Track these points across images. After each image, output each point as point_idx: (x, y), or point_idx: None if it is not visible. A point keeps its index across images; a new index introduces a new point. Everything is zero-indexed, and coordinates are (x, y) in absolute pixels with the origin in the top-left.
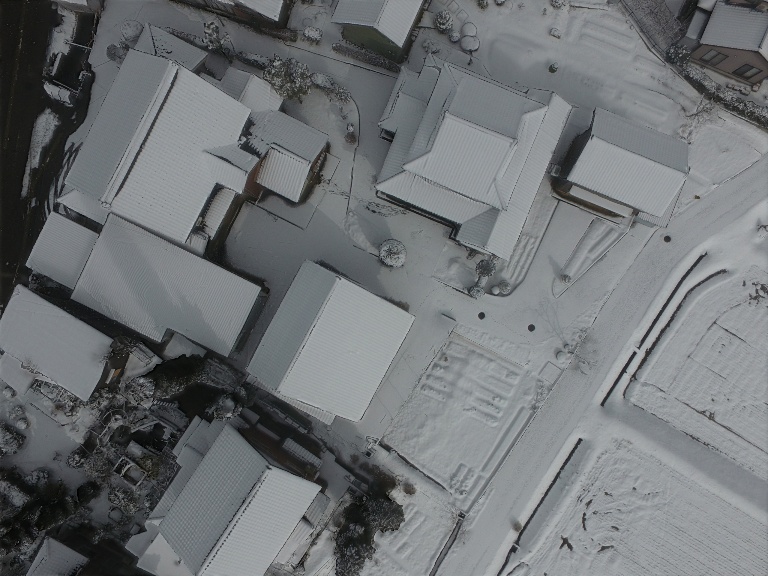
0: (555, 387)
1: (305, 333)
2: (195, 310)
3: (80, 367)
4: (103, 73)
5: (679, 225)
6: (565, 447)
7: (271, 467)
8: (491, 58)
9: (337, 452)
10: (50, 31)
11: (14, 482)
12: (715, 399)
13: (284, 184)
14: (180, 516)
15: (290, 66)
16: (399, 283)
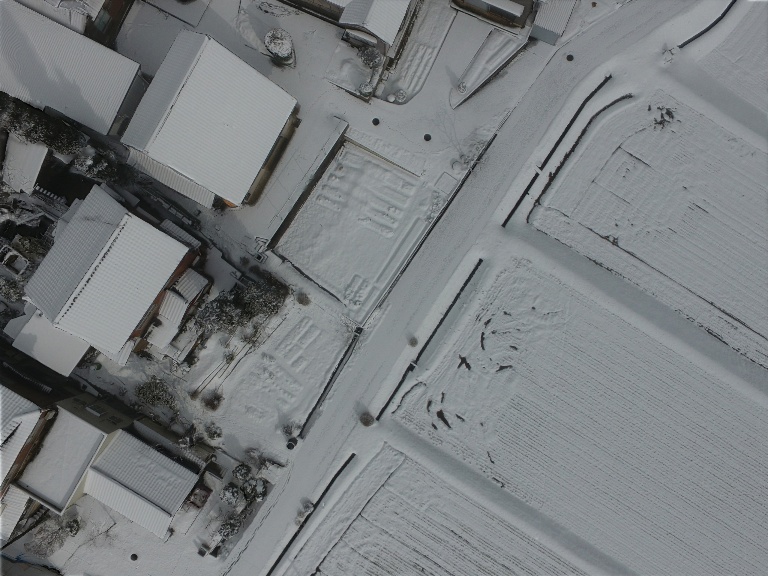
0: (454, 204)
1: (174, 93)
2: (74, 87)
3: None
4: None
5: (582, 44)
6: (463, 264)
7: (131, 215)
8: None
9: (227, 254)
10: None
11: None
12: (619, 224)
13: None
14: (44, 274)
15: None
16: (291, 83)
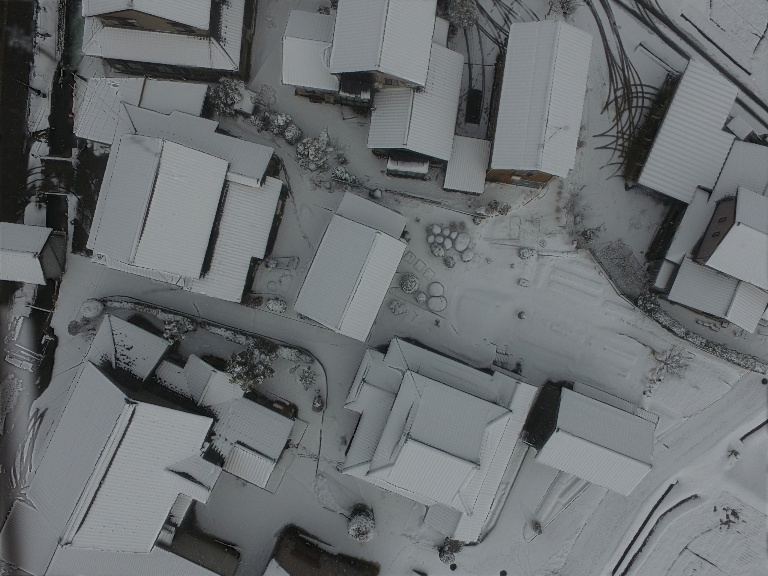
0: None
1: None
2: None
3: None
4: (66, 336)
5: None
6: None
7: None
8: (459, 316)
9: None
10: (11, 295)
11: None
12: None
13: (250, 474)
14: None
15: (253, 356)
16: (370, 543)
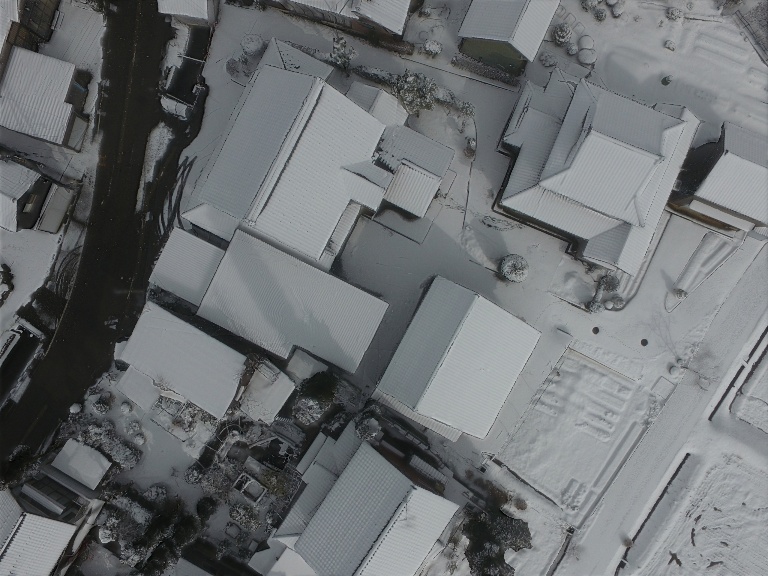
0: None
1: (443, 351)
2: (322, 326)
3: (213, 385)
4: (217, 87)
5: None
6: (674, 462)
7: (416, 487)
8: (608, 71)
9: (452, 468)
10: (164, 44)
11: (134, 498)
12: None
13: (411, 200)
14: (318, 535)
15: (417, 81)
16: (515, 298)
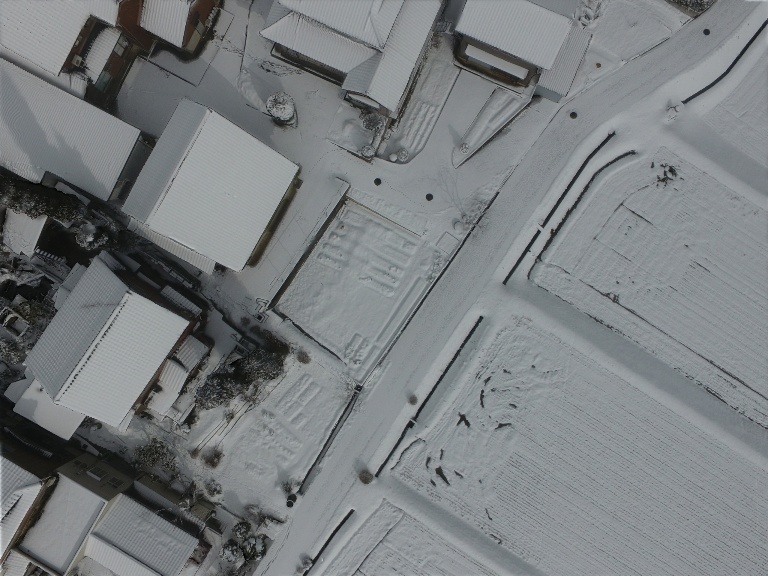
0: (455, 262)
1: (175, 166)
2: (74, 152)
3: None
4: None
5: (586, 101)
6: (464, 322)
7: (131, 292)
8: None
9: (228, 314)
10: None
11: None
12: (620, 281)
13: (166, 27)
14: (45, 347)
15: None
16: (292, 144)
